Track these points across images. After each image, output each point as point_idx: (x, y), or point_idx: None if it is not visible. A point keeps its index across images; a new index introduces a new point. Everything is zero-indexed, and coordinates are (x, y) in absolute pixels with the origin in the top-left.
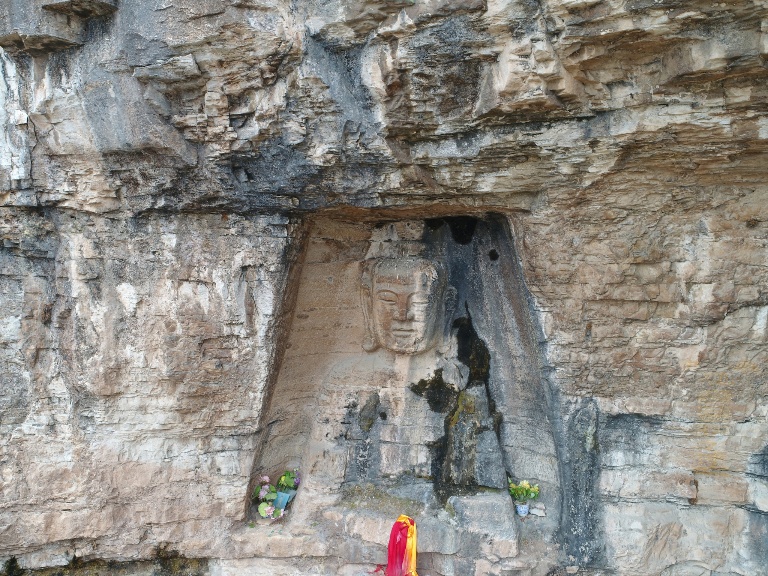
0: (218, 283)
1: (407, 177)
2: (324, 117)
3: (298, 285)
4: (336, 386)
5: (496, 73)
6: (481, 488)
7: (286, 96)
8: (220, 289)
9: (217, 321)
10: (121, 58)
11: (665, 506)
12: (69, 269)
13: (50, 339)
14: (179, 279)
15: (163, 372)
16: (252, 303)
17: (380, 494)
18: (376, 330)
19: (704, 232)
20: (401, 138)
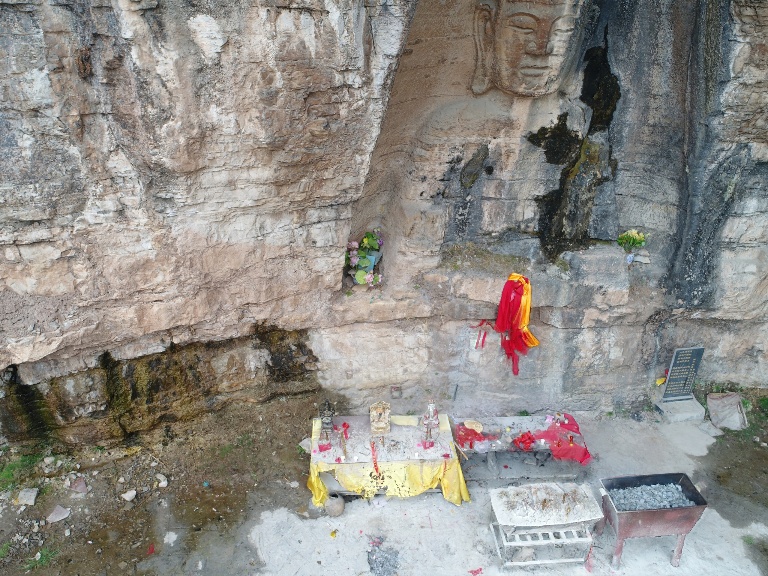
0: (332, 11)
1: None
2: None
3: None
4: (438, 139)
5: None
6: (592, 241)
7: None
8: (335, 20)
9: (327, 67)
10: None
11: None
12: None
13: (96, 100)
14: (277, 6)
15: (261, 139)
16: (370, 39)
17: (481, 252)
18: (499, 68)
19: None
20: None
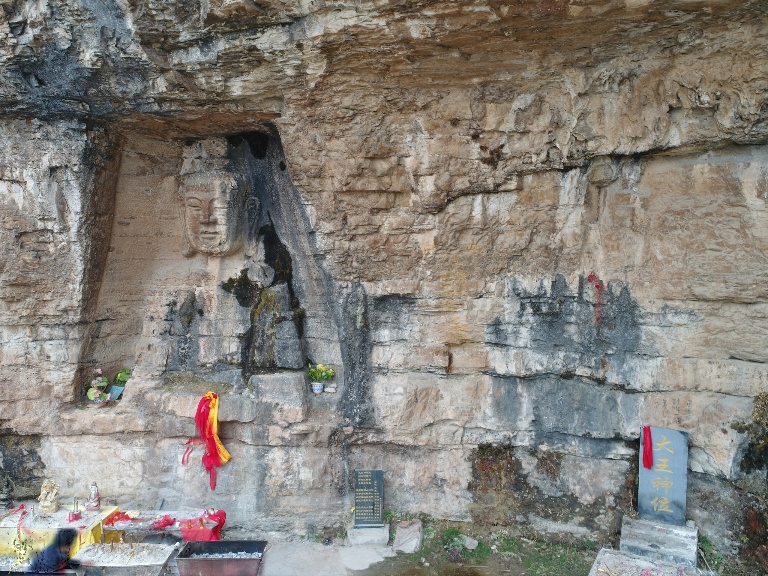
0: (29, 181)
1: (169, 81)
2: (84, 24)
3: (115, 193)
4: (158, 287)
5: None
6: (281, 370)
7: (49, 5)
8: (31, 187)
9: (31, 216)
10: None
11: (425, 375)
12: None
13: None
14: None
15: None
16: (63, 202)
17: (197, 380)
18: (188, 234)
19: (420, 131)
20: (157, 46)
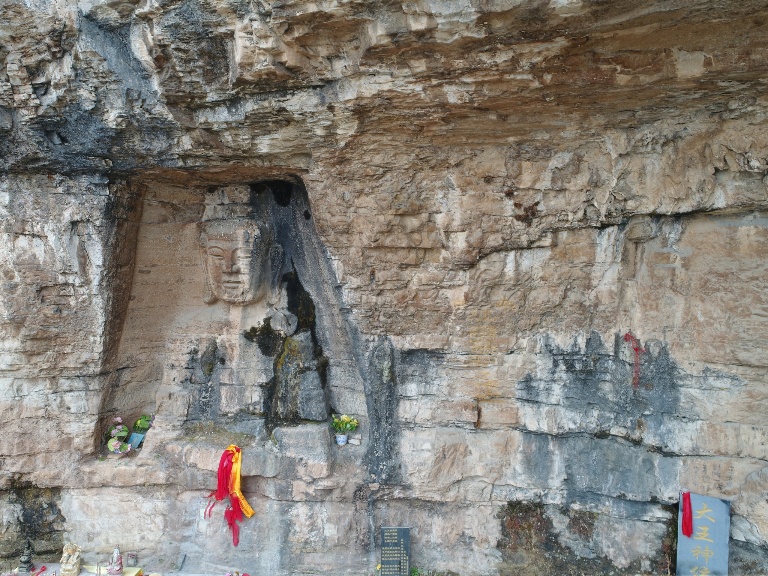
0: (50, 236)
1: (195, 139)
2: (109, 86)
3: (136, 242)
4: (179, 335)
5: (235, 48)
6: (304, 421)
7: (74, 67)
8: (52, 241)
9: (52, 271)
10: None
11: (453, 430)
12: None
13: None
14: (15, 233)
15: (4, 316)
16: (85, 255)
17: (219, 430)
18: (210, 283)
19: (452, 187)
20: (183, 105)
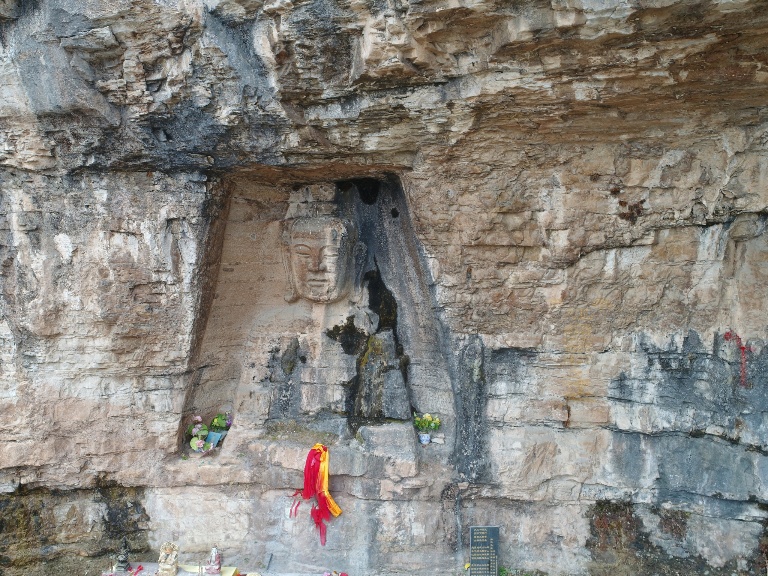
0: (146, 234)
1: (303, 137)
2: (226, 82)
3: (222, 240)
4: (260, 333)
5: (362, 44)
6: (388, 420)
7: (192, 64)
8: (148, 239)
9: (146, 269)
10: (49, 30)
11: (542, 429)
12: (11, 221)
13: None
14: (111, 230)
15: (98, 314)
16: (178, 253)
17: (300, 429)
18: (294, 281)
19: (557, 185)
20: (295, 102)
